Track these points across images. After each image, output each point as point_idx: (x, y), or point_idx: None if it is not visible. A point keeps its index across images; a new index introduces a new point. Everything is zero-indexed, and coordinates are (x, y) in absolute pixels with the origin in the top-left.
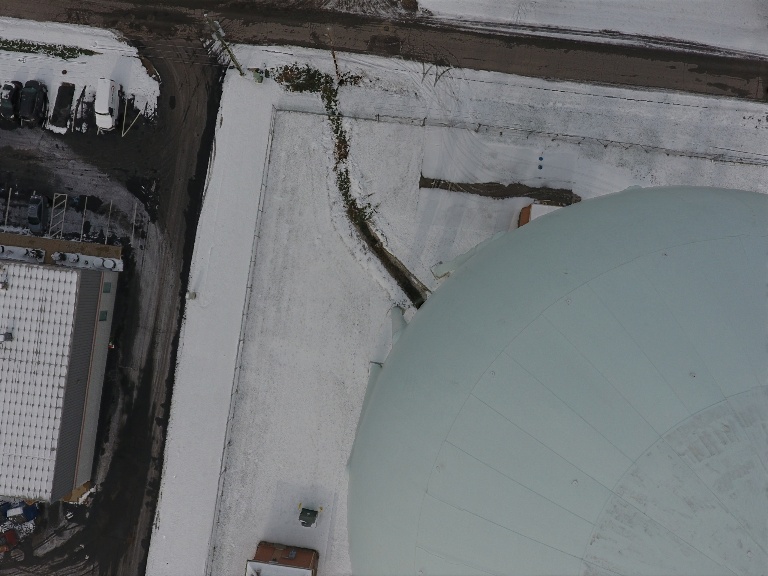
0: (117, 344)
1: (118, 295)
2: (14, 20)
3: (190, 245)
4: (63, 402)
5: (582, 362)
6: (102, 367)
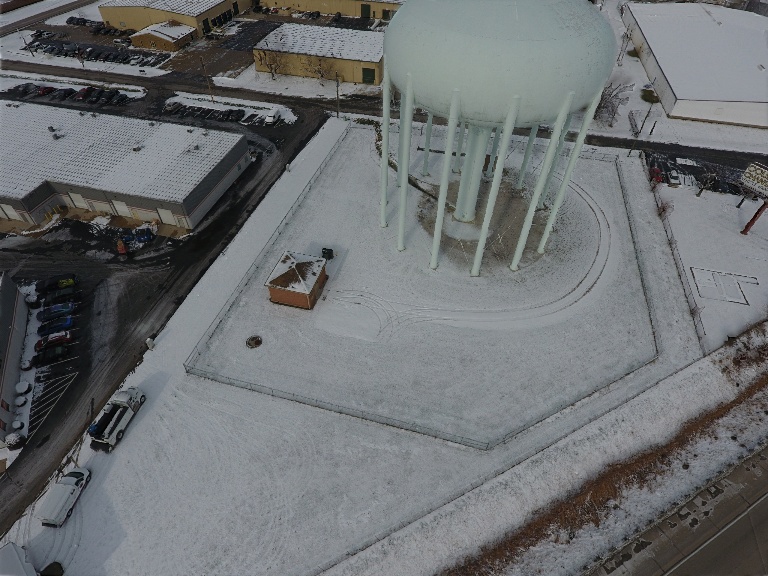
0: (238, 183)
1: (248, 168)
2: (240, 99)
3: (294, 157)
4: (213, 169)
5: None
6: (226, 187)
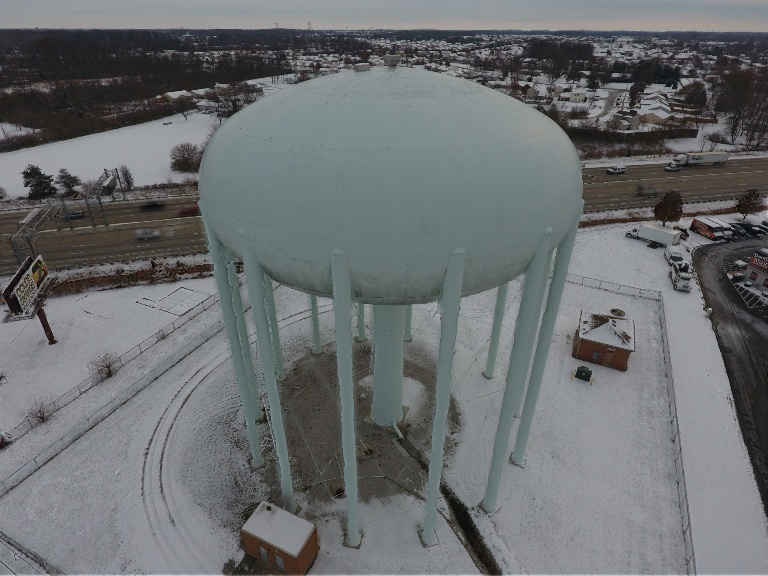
0: None
1: None
2: None
3: None
4: None
5: (459, 124)
6: None
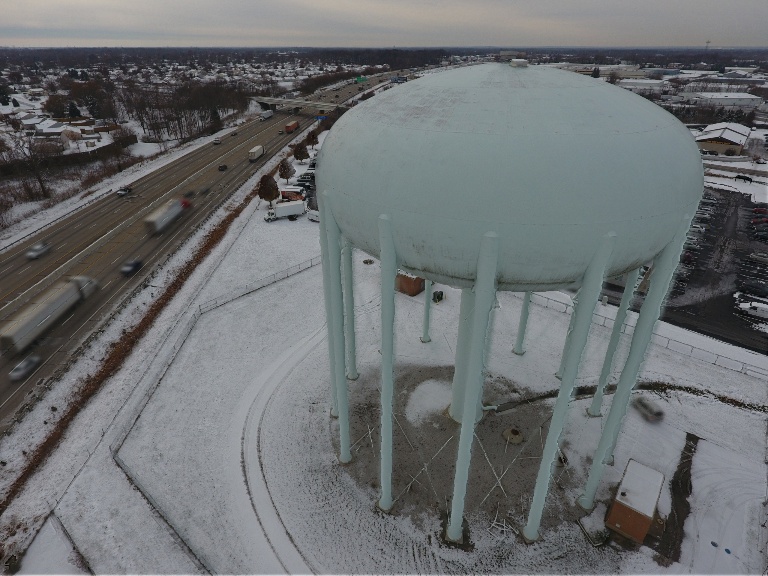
0: None
1: (612, 284)
2: None
3: None
4: None
5: None
6: None
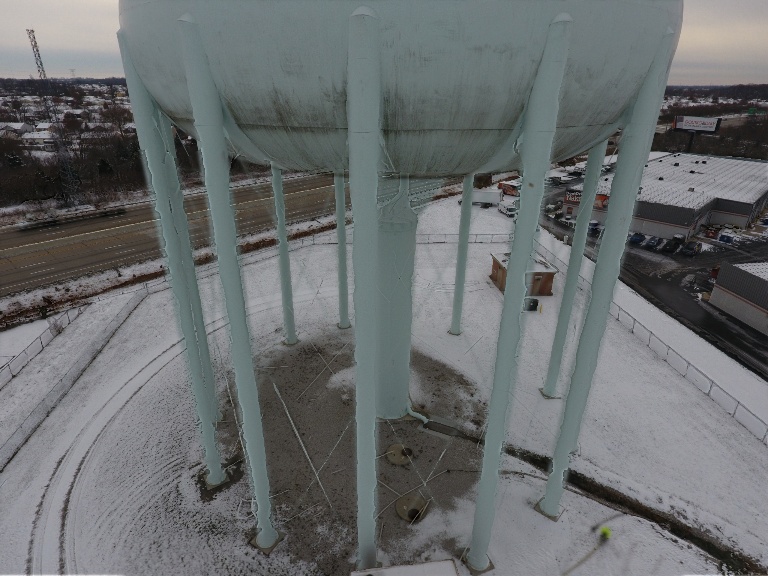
0: None
1: None
2: None
3: None
4: None
5: None
6: None
